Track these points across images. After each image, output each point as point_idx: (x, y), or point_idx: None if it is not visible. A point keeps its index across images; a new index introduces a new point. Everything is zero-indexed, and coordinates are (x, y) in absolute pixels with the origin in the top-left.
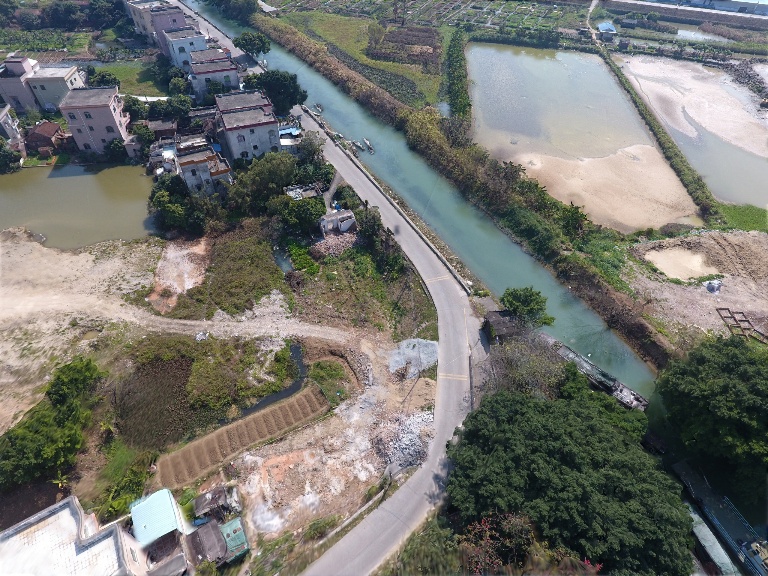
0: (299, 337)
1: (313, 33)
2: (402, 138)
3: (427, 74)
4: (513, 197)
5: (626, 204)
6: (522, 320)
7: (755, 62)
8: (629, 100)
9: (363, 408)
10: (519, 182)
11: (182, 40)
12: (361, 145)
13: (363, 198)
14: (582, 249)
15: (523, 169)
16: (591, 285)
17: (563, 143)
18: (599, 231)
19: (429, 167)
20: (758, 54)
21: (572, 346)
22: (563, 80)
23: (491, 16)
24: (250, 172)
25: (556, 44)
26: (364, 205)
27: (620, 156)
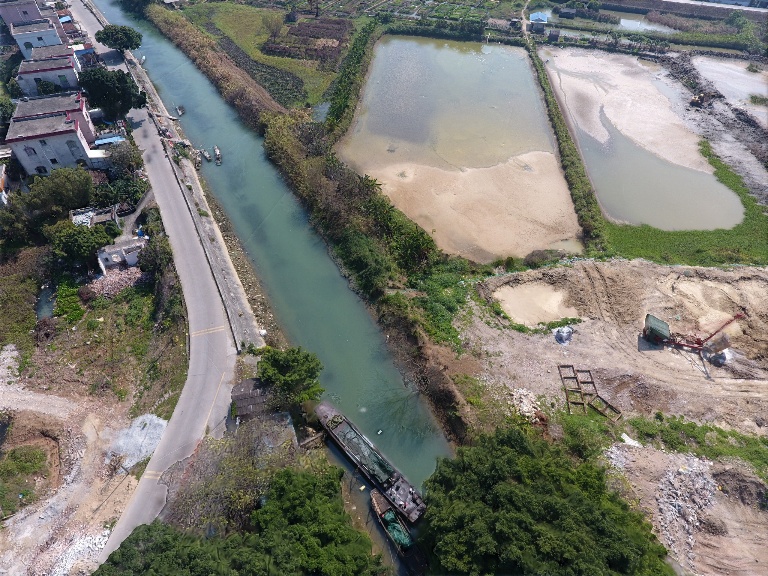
0: (12, 411)
1: (213, 26)
2: (261, 146)
3: (321, 71)
4: (351, 219)
5: (497, 225)
6: (274, 395)
7: (696, 54)
8: (542, 99)
9: (42, 518)
10: (368, 200)
11: (27, 34)
12: (208, 155)
13: (166, 223)
14: (415, 286)
15: (378, 184)
16: (408, 335)
17: (448, 150)
18: (445, 262)
19: (278, 181)
20: (703, 46)
21: (362, 419)
22: (475, 76)
23: (419, 6)
24: (24, 193)
25: (479, 36)
26: (164, 232)
27: (510, 165)
